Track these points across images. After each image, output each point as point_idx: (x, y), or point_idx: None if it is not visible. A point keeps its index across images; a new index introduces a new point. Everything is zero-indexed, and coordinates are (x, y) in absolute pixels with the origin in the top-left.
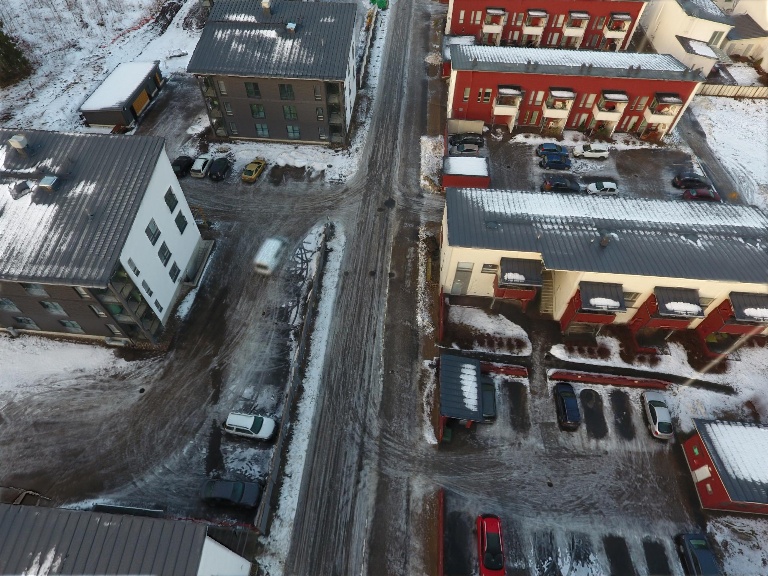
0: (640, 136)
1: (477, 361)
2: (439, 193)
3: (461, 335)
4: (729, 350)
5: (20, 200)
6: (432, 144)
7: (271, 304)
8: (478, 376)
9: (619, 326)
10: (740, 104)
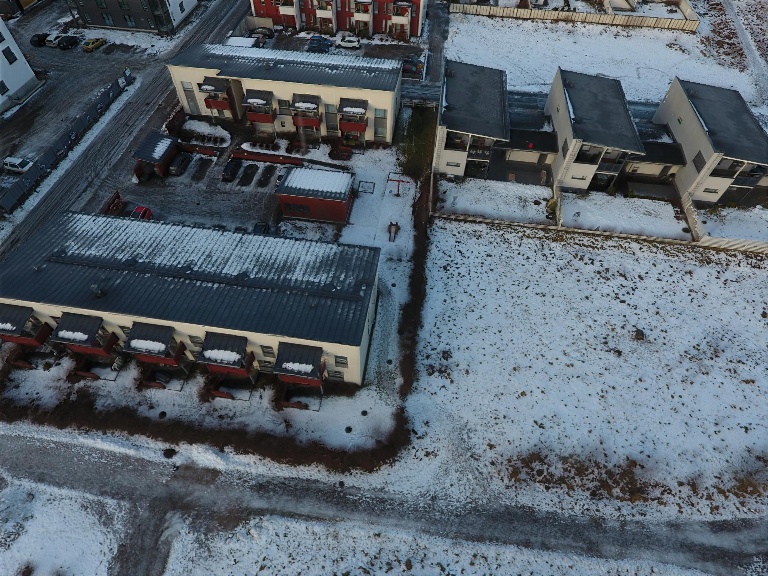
0: (393, 36)
1: (175, 138)
2: None
3: (185, 134)
4: (359, 149)
5: None
6: None
7: (69, 116)
8: (171, 144)
9: (293, 134)
10: (491, 21)
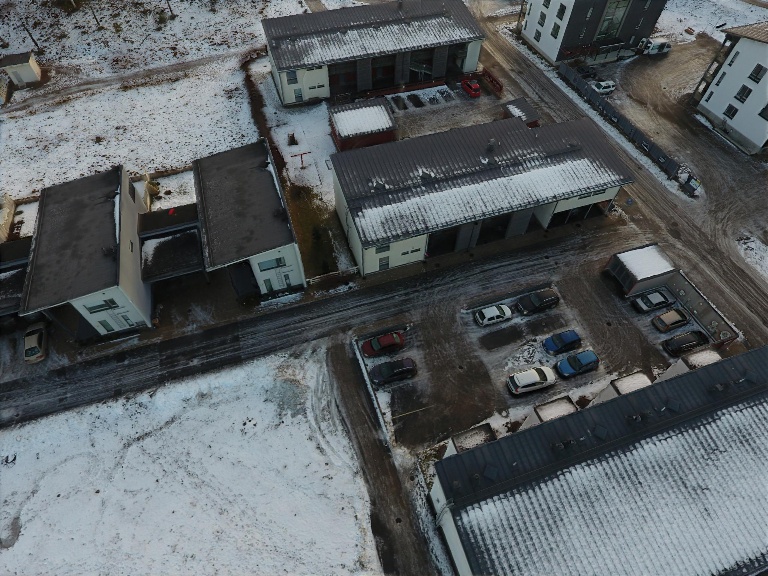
0: None
1: None
2: None
3: None
4: None
5: None
6: None
7: (660, 138)
8: None
9: None
10: None
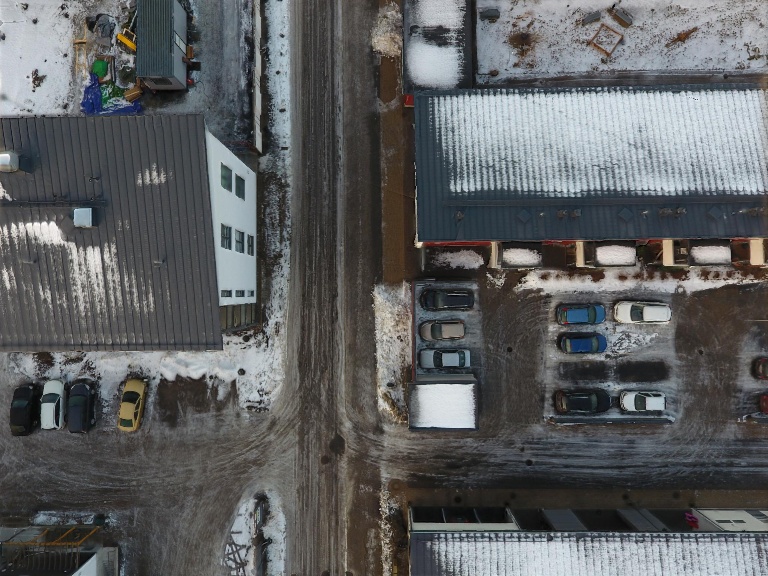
0: None
1: None
2: (405, 422)
3: None
4: None
5: None
6: (392, 318)
7: None
8: None
9: None
10: None
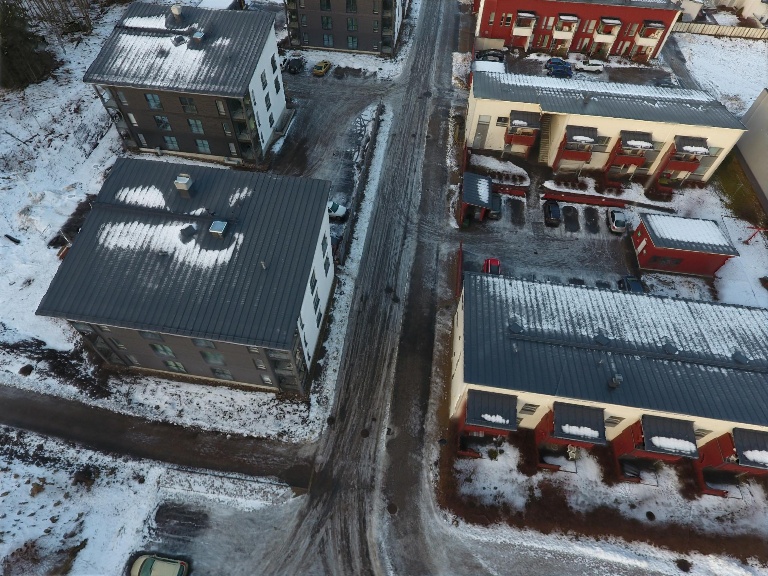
0: (631, 58)
1: (490, 178)
2: (466, 89)
3: (479, 171)
4: (676, 188)
5: (180, 47)
6: (462, 56)
7: (339, 149)
8: (490, 186)
9: (596, 171)
10: (719, 41)
